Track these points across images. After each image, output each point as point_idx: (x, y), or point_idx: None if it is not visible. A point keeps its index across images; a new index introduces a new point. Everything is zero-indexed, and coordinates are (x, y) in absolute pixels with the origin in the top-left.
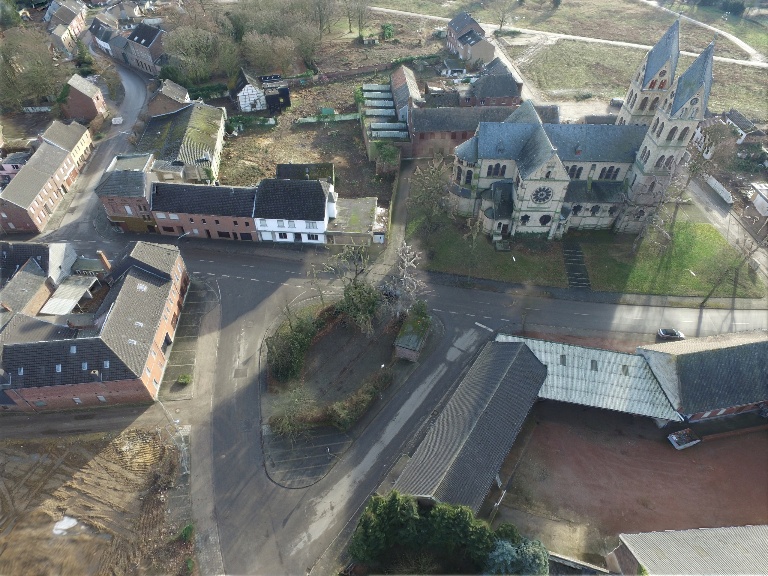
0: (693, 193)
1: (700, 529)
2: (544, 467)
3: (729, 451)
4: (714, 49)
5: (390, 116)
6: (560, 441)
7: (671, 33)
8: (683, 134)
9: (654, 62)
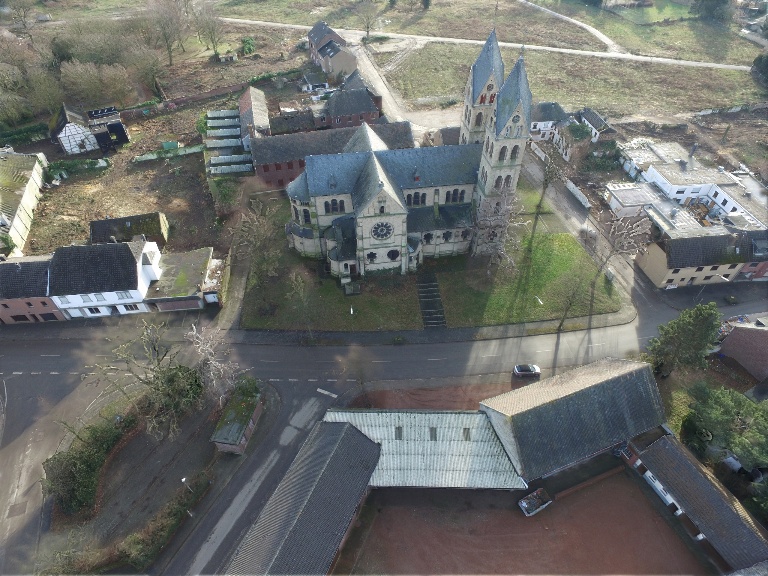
0: (553, 200)
1: None
2: (382, 571)
3: (583, 507)
4: (575, 43)
5: (235, 146)
6: (402, 531)
7: (490, 45)
8: (514, 152)
9: (479, 76)
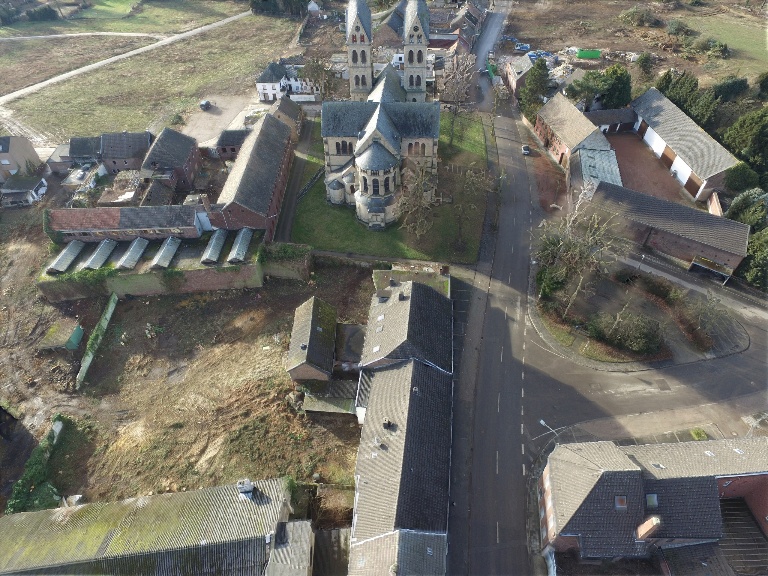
0: None
1: (682, 158)
2: None
3: None
4: (124, 45)
5: (180, 245)
6: None
7: None
8: None
9: (364, 20)
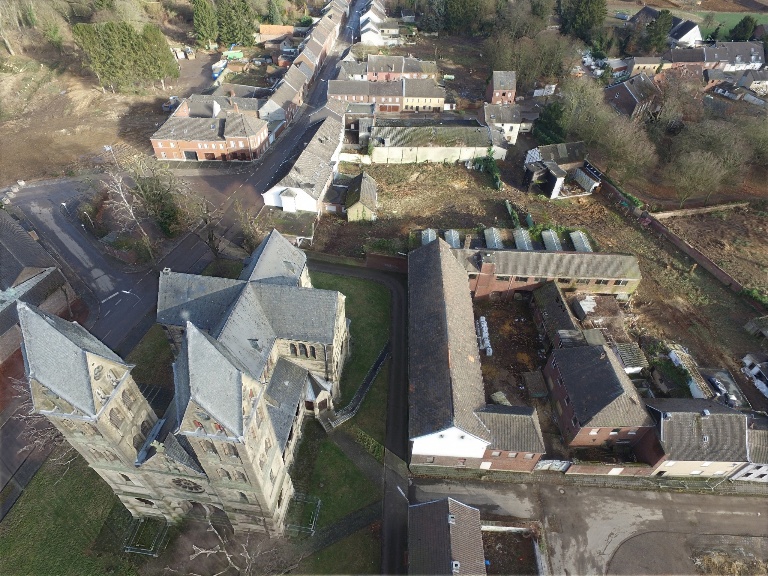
0: None
1: None
2: None
3: None
4: None
5: None
6: None
7: None
8: None
9: None
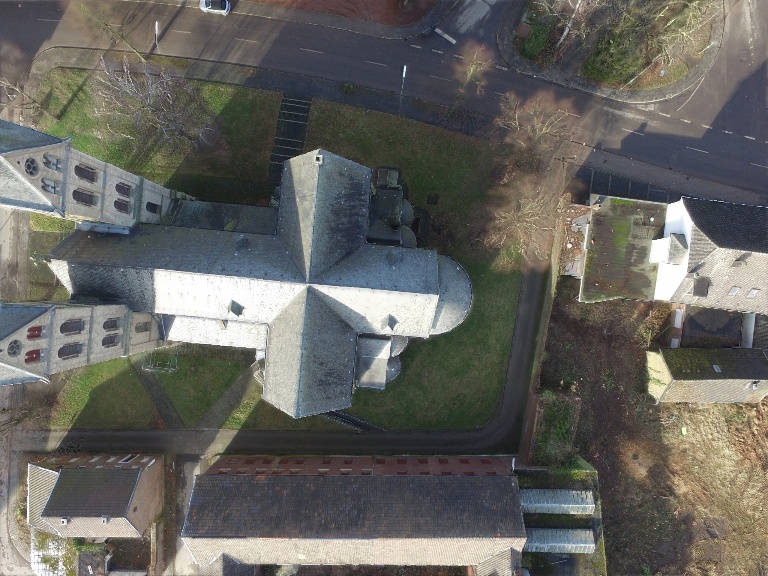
0: None
1: None
2: None
3: None
4: None
5: None
6: None
7: None
8: None
9: None
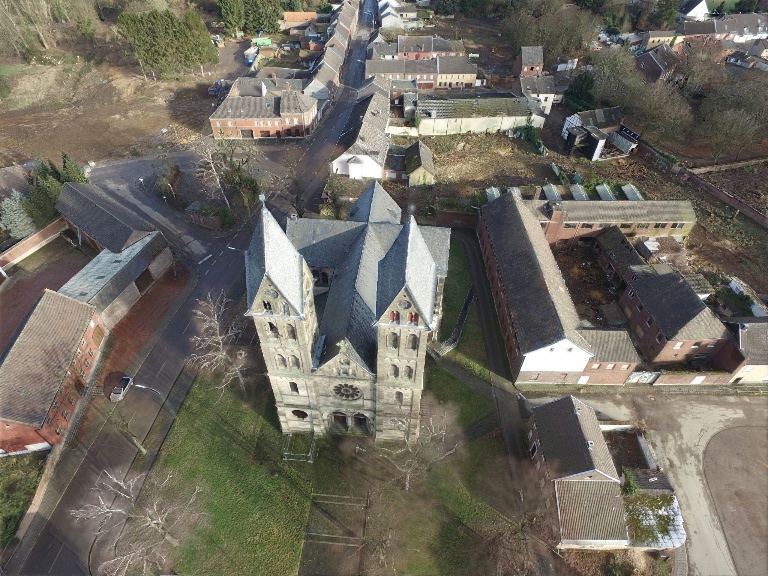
0: None
1: None
2: (75, 265)
3: None
4: None
5: None
6: None
7: None
8: None
9: None
